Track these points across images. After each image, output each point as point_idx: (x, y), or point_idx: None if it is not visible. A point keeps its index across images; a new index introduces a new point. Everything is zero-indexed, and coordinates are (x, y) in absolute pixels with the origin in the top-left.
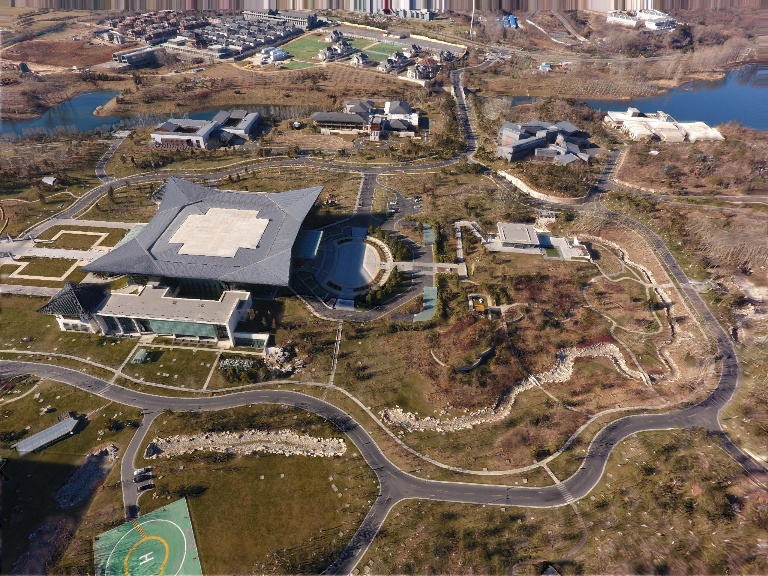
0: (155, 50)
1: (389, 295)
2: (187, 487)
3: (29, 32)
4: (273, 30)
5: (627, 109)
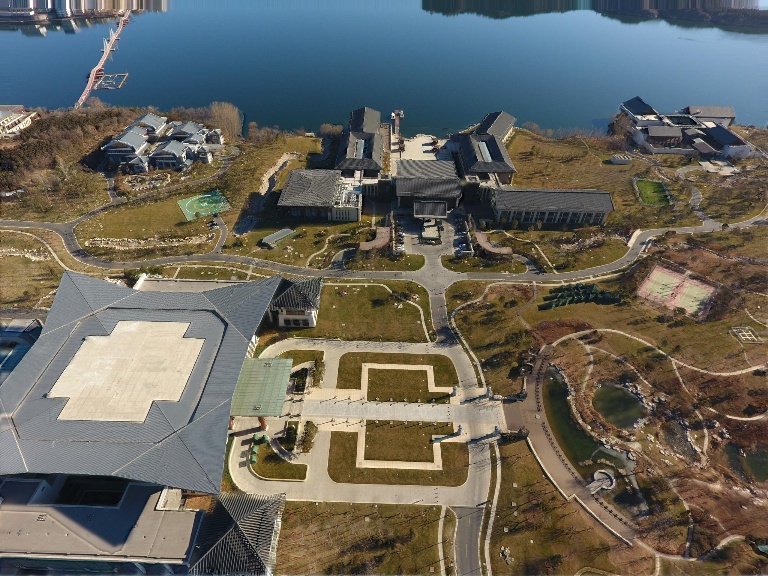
0: None
1: None
2: (187, 224)
3: None
4: None
5: None
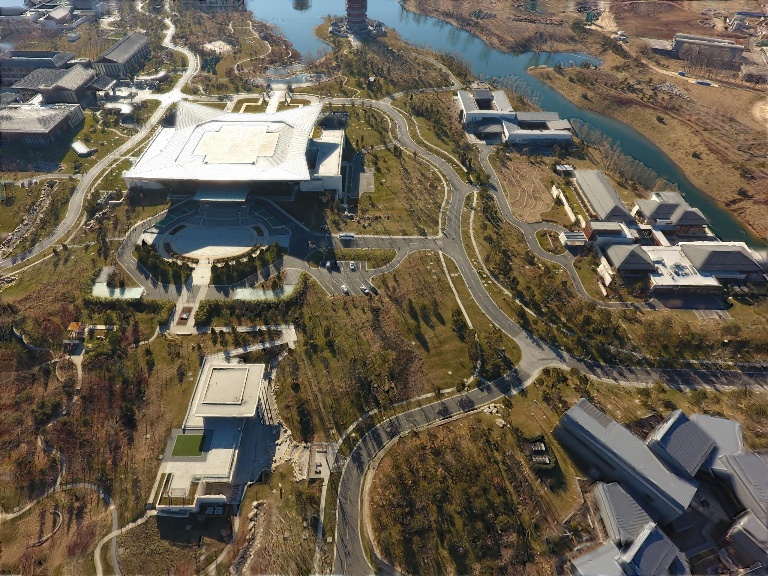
0: (726, 47)
1: None
2: (13, 199)
3: None
4: None
5: None
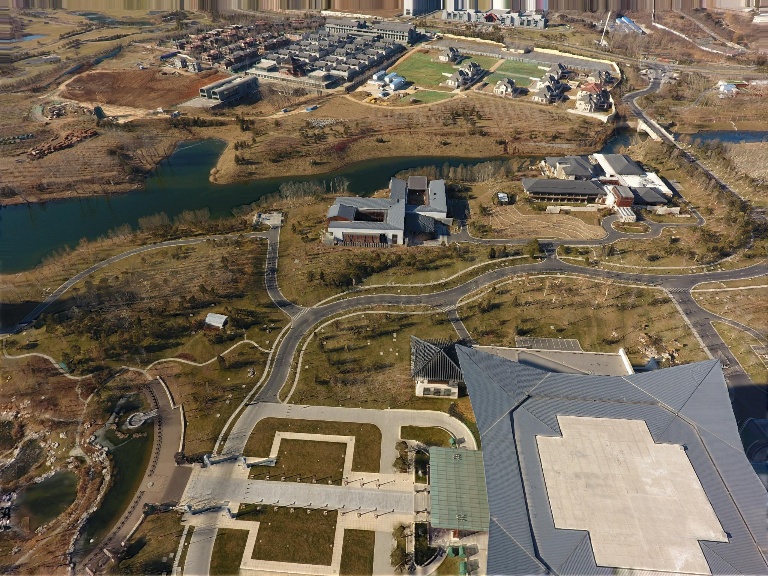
0: (247, 81)
1: None
2: None
3: (85, 60)
4: (371, 48)
5: None
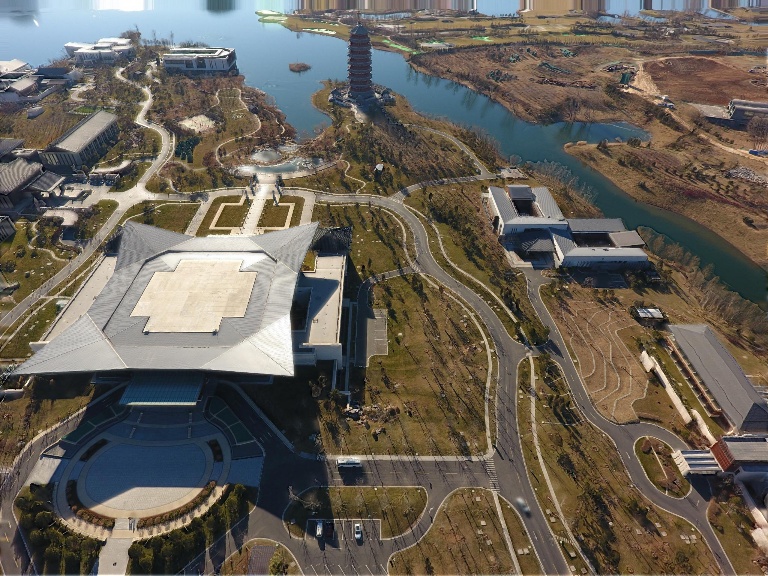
0: None
1: None
2: None
3: (727, 49)
4: None
5: None
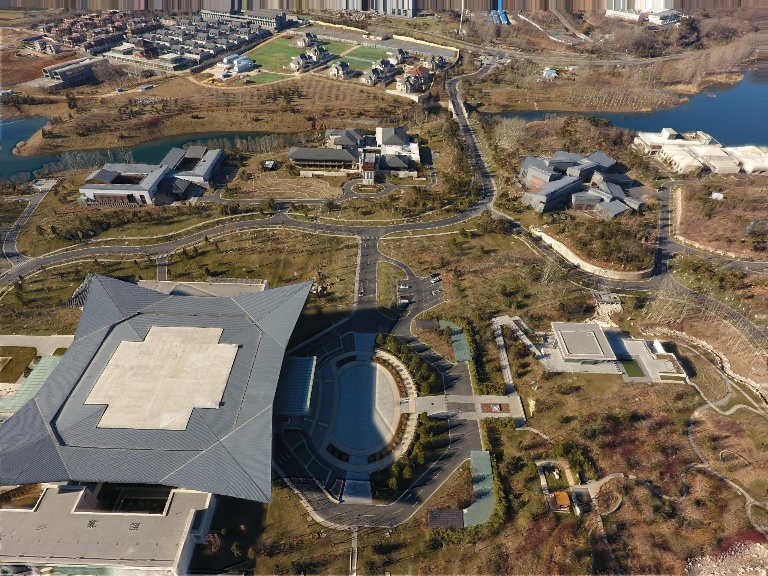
0: (95, 62)
1: (420, 467)
2: None
3: None
4: (236, 33)
5: (661, 129)
